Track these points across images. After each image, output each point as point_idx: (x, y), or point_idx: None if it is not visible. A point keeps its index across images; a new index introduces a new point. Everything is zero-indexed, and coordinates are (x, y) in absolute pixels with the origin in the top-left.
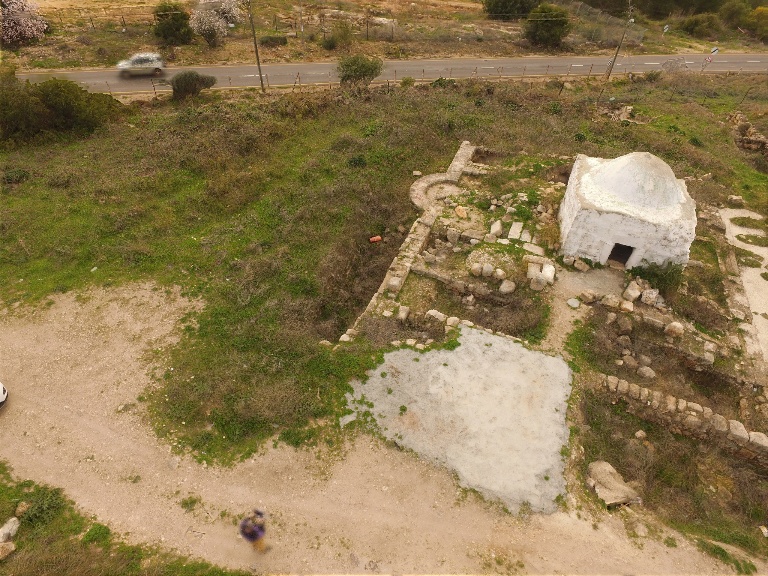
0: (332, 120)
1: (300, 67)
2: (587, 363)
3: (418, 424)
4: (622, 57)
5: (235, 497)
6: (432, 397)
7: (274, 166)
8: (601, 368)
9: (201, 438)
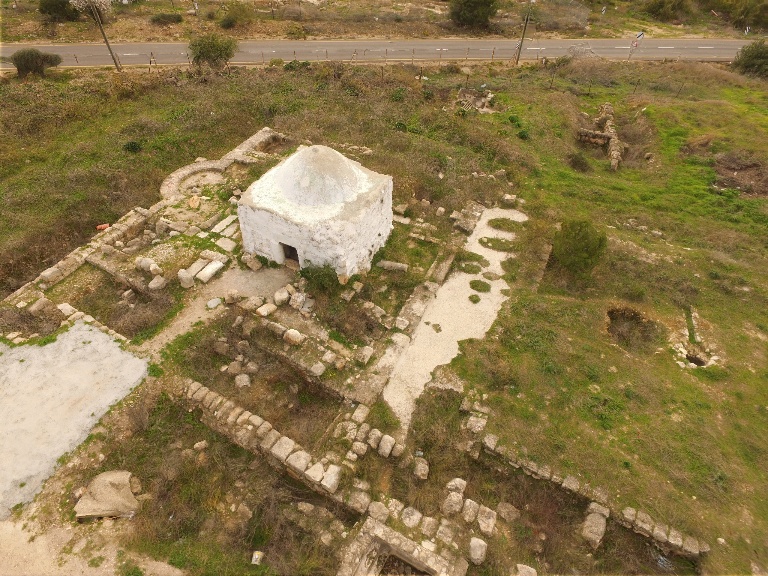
0: (149, 102)
1: (179, 46)
2: (179, 367)
3: None
4: (531, 41)
5: None
6: None
7: None
8: (194, 373)
9: None
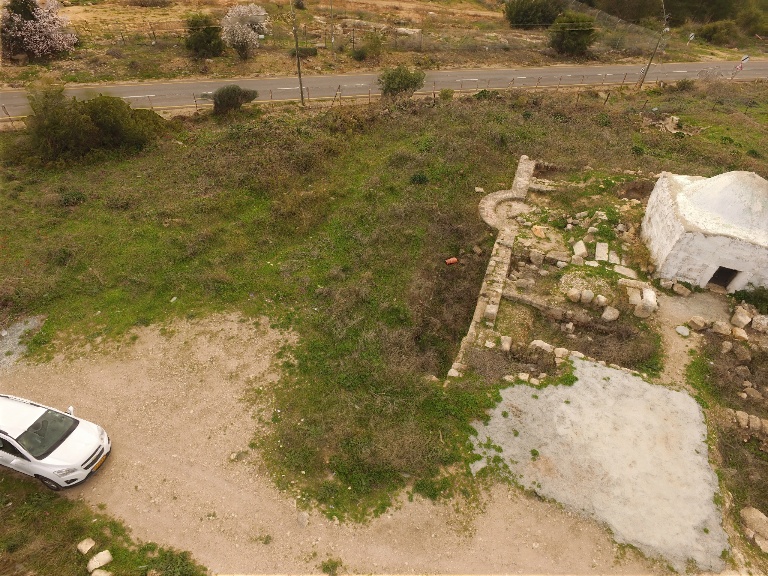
0: (383, 135)
1: (334, 79)
2: (712, 397)
3: (554, 470)
4: None
5: (378, 559)
6: (562, 439)
7: (335, 184)
8: (727, 402)
9: (325, 490)
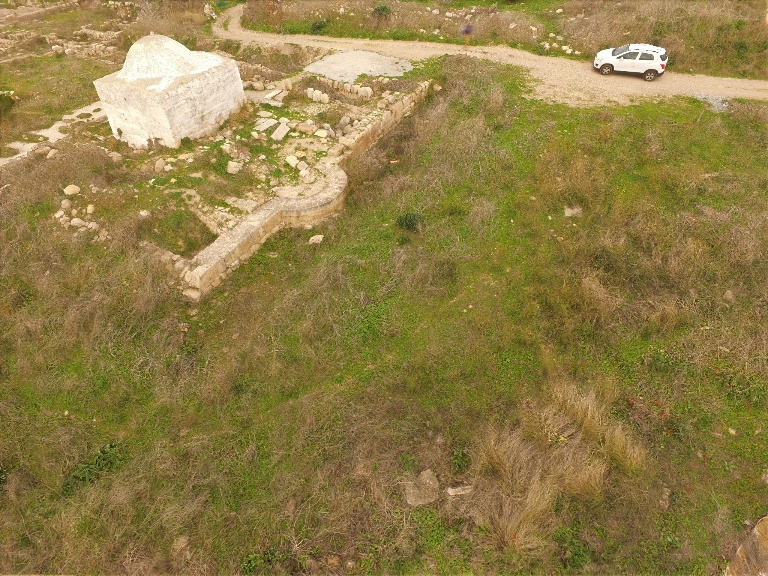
0: None
1: None
2: None
3: None
4: None
5: (468, 53)
6: None
7: (538, 226)
8: None
9: None
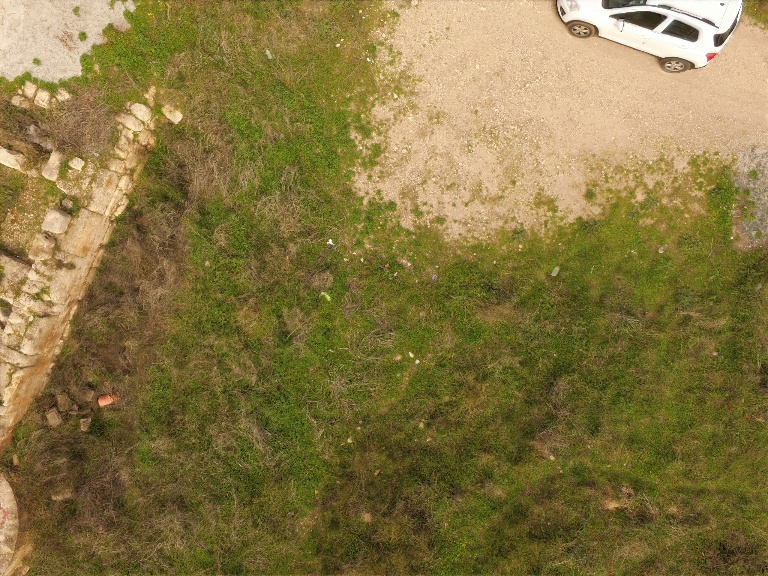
0: None
1: None
2: None
3: None
4: None
5: None
6: (22, 0)
7: None
8: None
9: None
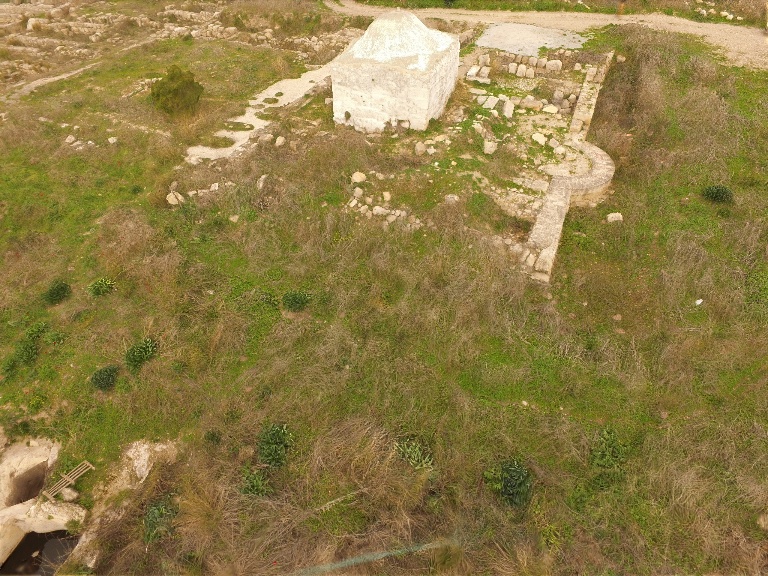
0: None
1: None
2: None
3: None
4: None
5: (626, 22)
6: None
7: None
8: None
9: None
